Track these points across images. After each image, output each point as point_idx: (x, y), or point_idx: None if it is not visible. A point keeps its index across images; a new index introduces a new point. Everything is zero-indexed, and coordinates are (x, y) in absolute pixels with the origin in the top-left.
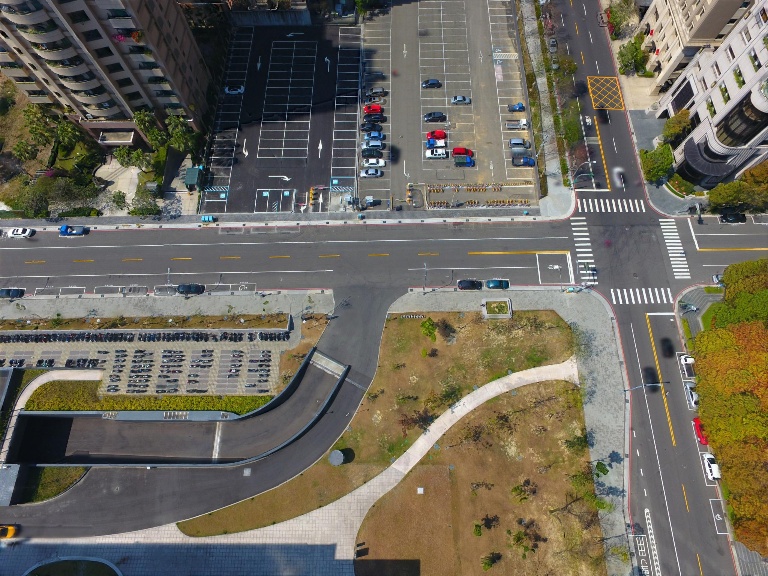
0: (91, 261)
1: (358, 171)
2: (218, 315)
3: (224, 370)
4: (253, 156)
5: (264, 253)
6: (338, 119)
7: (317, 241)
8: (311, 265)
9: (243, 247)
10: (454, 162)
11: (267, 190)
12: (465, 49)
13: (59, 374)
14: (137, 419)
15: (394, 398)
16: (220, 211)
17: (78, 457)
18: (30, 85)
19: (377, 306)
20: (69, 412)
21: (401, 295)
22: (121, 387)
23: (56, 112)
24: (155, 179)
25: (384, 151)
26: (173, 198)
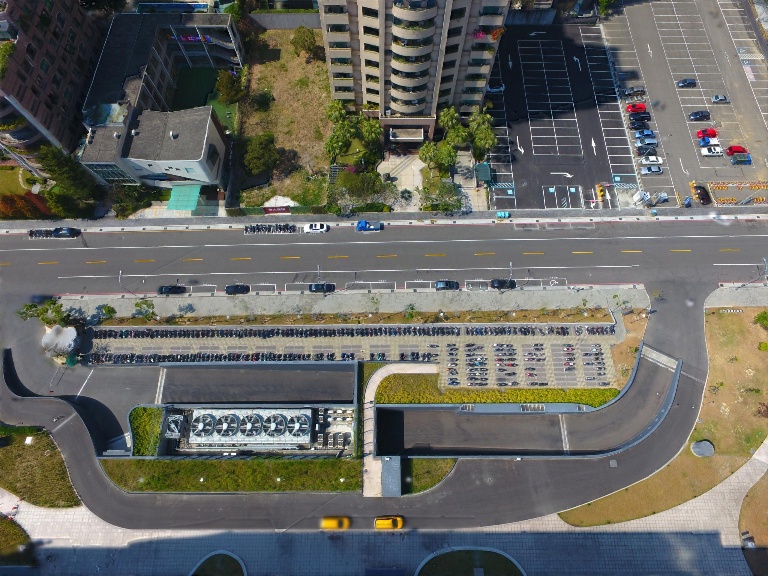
0: (394, 256)
1: (637, 168)
2: (537, 309)
3: (559, 363)
4: (530, 153)
5: (566, 249)
6: (603, 117)
7: (616, 237)
8: (616, 260)
9: (543, 243)
10: (732, 160)
11: (553, 187)
12: (709, 49)
13: (397, 367)
14: (495, 411)
15: (736, 391)
16: (511, 207)
17: (420, 450)
18: (347, 81)
19: (692, 301)
20: (425, 405)
21: (713, 290)
22: (460, 380)
23: (350, 108)
24: (442, 175)
25: (657, 149)
26: (460, 194)
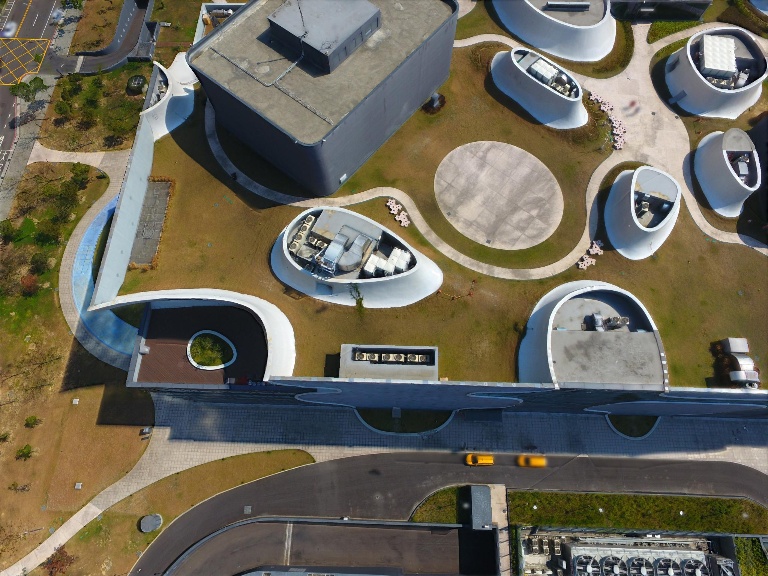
0: None
1: None
2: None
3: None
4: None
5: None
6: None
7: None
8: None
9: None
10: None
11: None
12: None
13: None
14: (364, 575)
15: None
16: None
17: (442, 528)
18: None
19: None
20: None
21: None
22: None
23: None
24: None
25: None
26: None
